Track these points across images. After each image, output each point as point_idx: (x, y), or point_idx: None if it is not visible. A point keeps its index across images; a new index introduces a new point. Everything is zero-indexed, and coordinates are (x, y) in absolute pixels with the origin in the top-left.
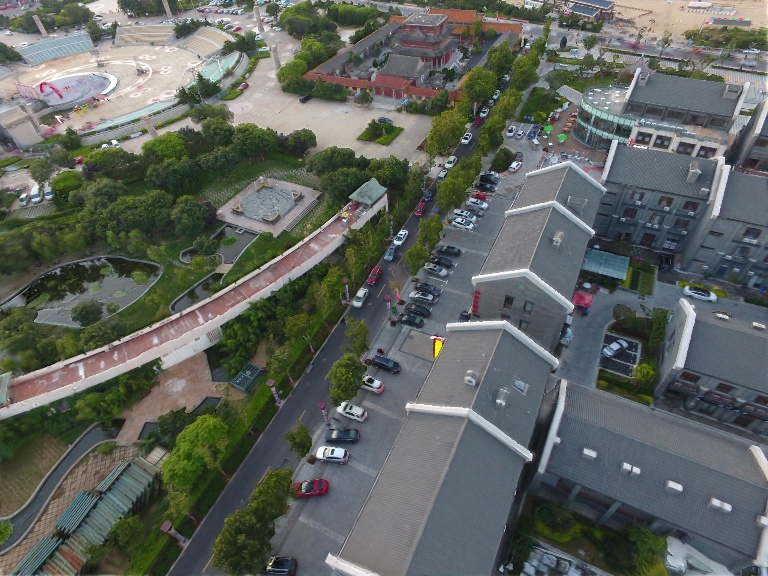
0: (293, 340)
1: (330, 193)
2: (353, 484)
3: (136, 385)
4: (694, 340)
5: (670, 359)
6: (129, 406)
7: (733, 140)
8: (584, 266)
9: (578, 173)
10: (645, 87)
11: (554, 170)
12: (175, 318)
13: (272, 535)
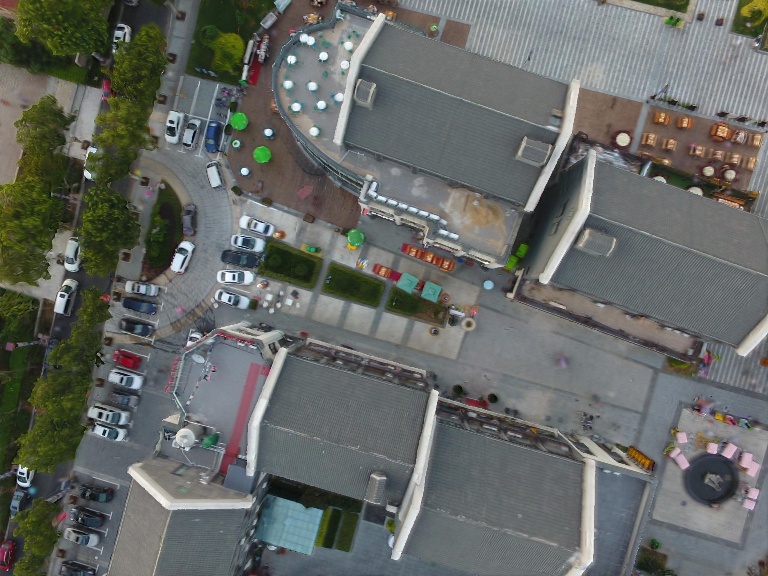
0: None
1: None
2: None
3: None
4: None
5: None
6: None
7: None
8: (261, 535)
9: None
10: (372, 111)
11: None
12: None
13: None
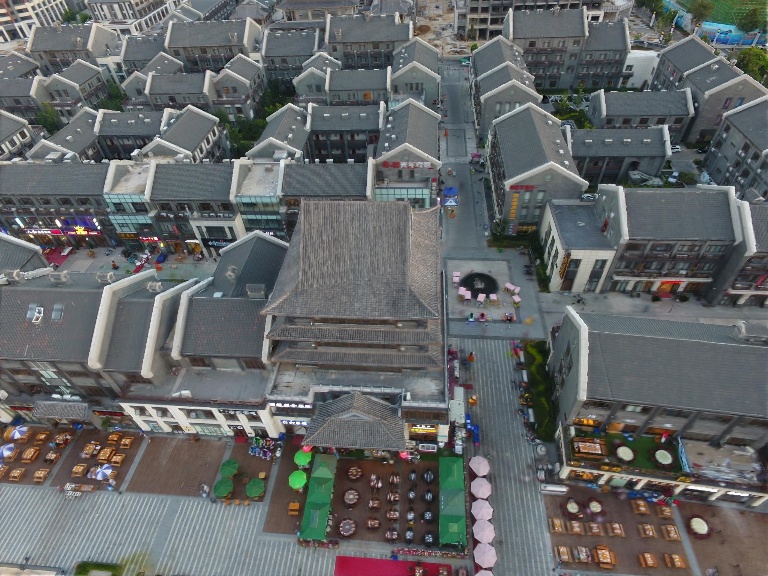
0: None
1: None
2: None
3: None
4: None
5: None
6: None
7: (767, 551)
8: None
9: None
10: None
11: None
12: None
13: None
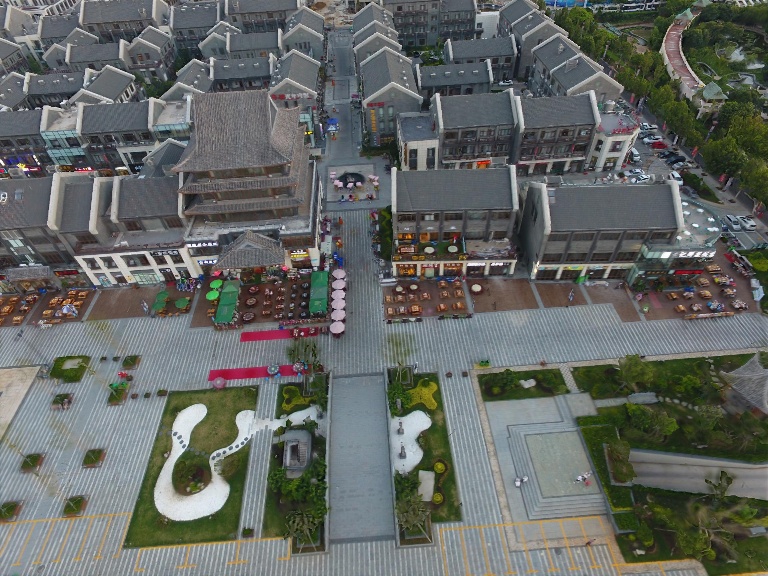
0: None
1: None
2: None
3: None
4: None
5: None
6: None
7: (515, 295)
8: None
9: None
10: None
11: None
12: None
13: None
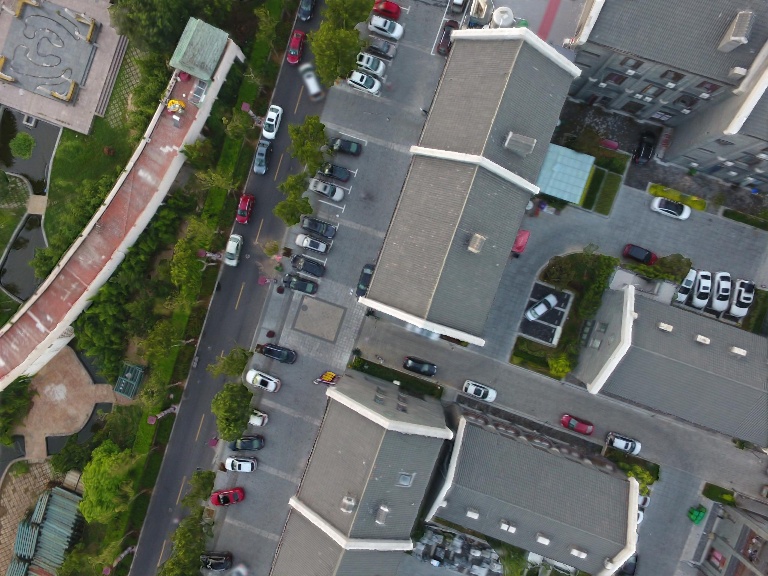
0: (158, 372)
1: (137, 47)
2: (266, 487)
3: (11, 409)
4: (619, 365)
5: (590, 364)
6: (19, 423)
7: None
8: None
9: (537, 49)
10: None
11: (498, 39)
12: (7, 329)
13: (200, 566)
